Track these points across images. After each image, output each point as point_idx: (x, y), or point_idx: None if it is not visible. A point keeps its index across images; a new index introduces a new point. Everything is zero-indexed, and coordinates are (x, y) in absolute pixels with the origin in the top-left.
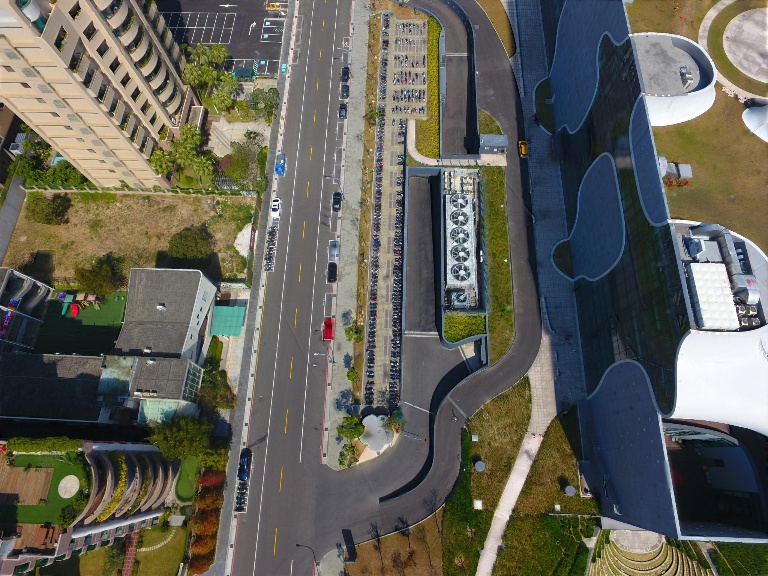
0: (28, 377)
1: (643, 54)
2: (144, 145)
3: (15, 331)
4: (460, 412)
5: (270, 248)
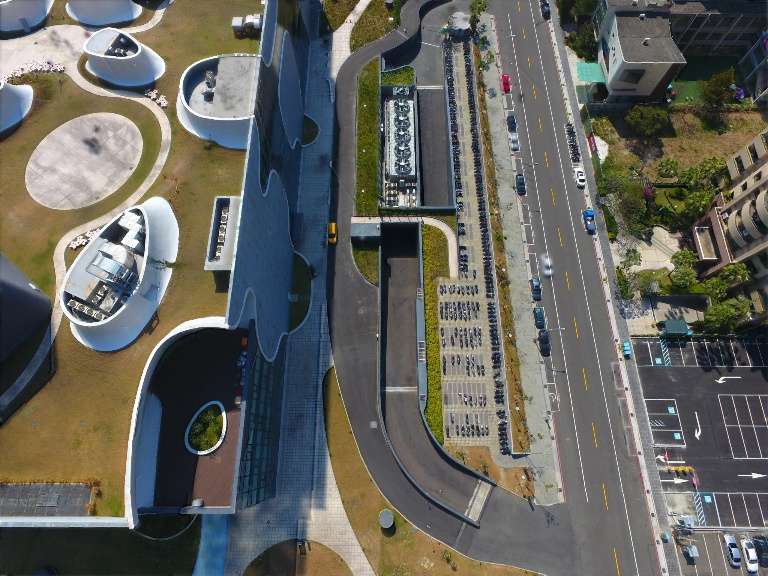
0: (722, 1)
1: (246, 96)
2: (739, 167)
3: (759, 54)
4: (401, 33)
5: (574, 142)
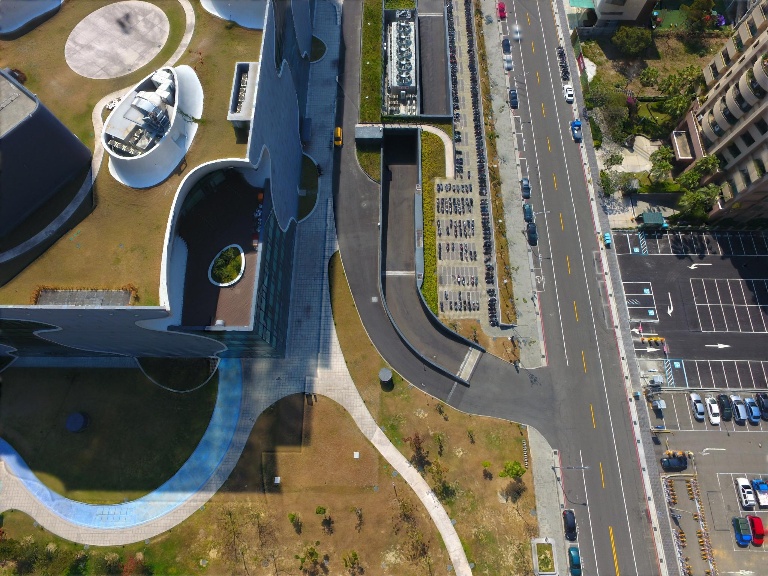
0: None
1: None
2: None
3: None
4: None
5: (564, 63)
